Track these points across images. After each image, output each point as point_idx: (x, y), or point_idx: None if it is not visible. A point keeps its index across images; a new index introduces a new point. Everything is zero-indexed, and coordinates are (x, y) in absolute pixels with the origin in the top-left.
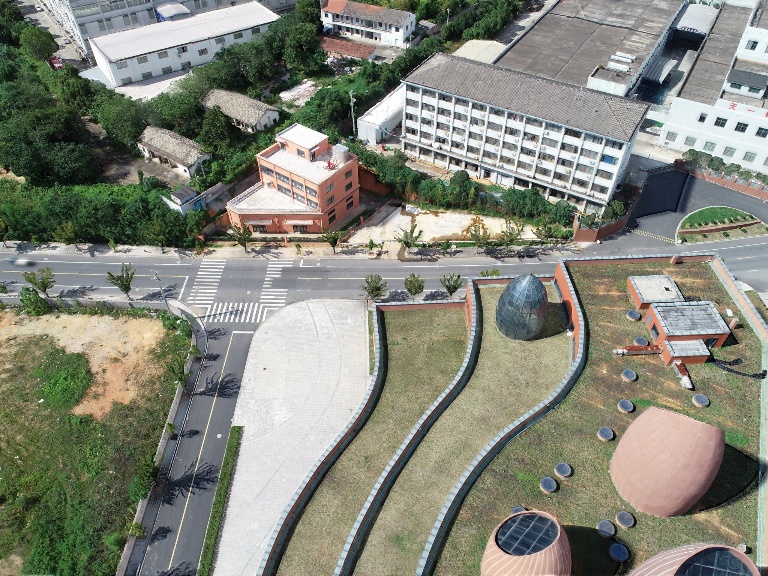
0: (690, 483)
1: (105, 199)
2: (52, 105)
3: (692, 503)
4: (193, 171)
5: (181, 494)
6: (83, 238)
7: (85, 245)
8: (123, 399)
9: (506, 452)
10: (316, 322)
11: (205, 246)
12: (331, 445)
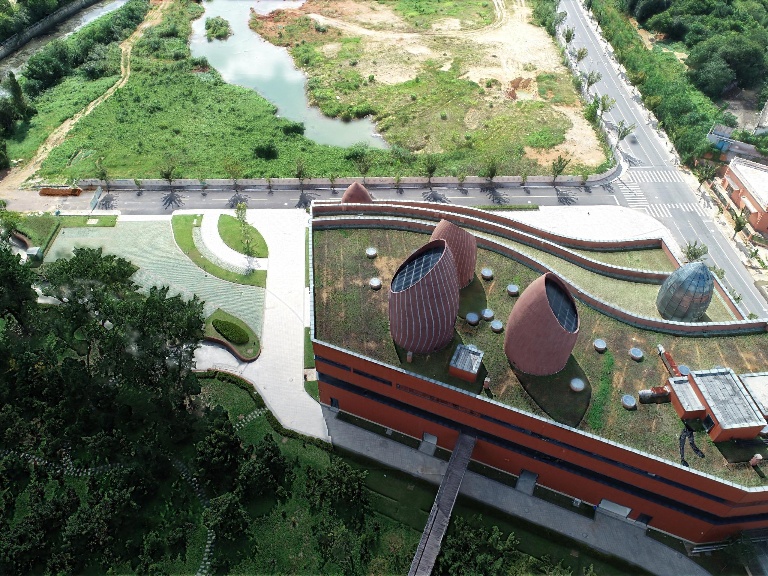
0: (514, 314)
1: (690, 100)
2: (760, 43)
3: (511, 346)
4: (759, 132)
5: (488, 194)
6: (659, 114)
7: (655, 119)
8: (540, 161)
9: (533, 273)
10: (646, 234)
11: (691, 168)
12: (526, 223)
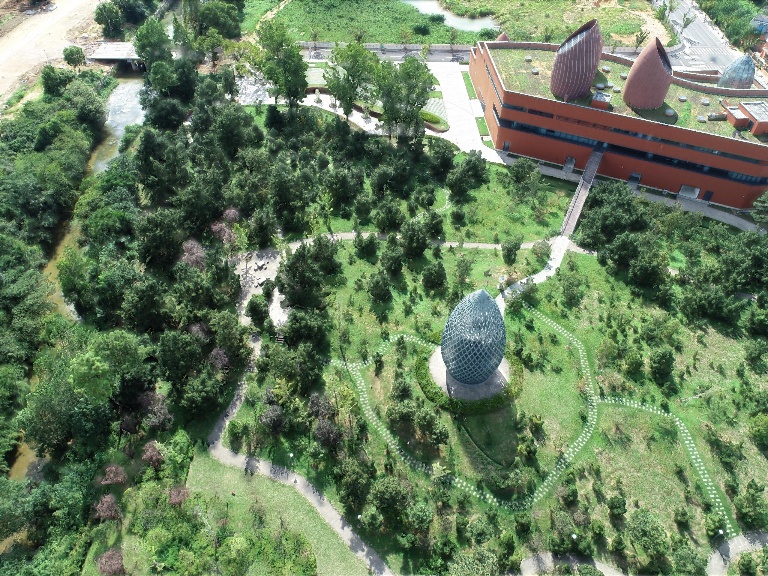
0: None
1: (738, 1)
2: None
3: None
4: None
5: None
6: (713, 16)
7: (710, 19)
8: None
9: None
10: None
11: (737, 47)
12: None
